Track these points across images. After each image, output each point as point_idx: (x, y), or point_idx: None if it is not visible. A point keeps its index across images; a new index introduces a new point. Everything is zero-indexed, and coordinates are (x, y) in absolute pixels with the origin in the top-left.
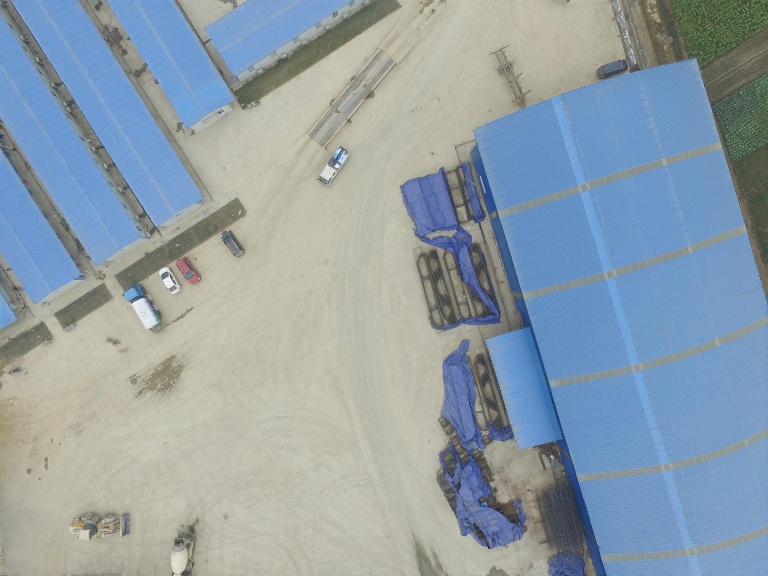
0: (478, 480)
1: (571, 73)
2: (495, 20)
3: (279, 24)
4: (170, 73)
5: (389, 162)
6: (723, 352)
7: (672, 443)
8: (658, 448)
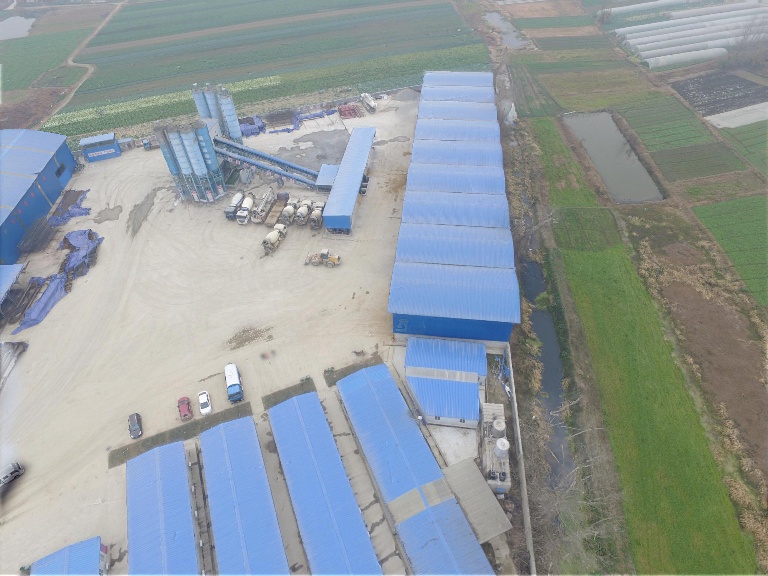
0: None
1: None
2: None
3: None
4: None
5: None
6: None
7: None
8: None
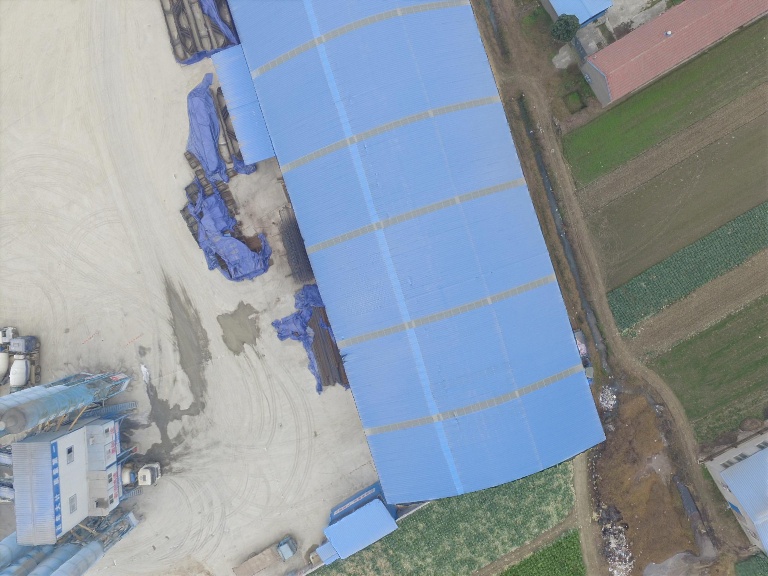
0: (222, 212)
1: None
2: None
3: None
4: None
5: None
6: (406, 23)
7: (355, 114)
8: (342, 121)
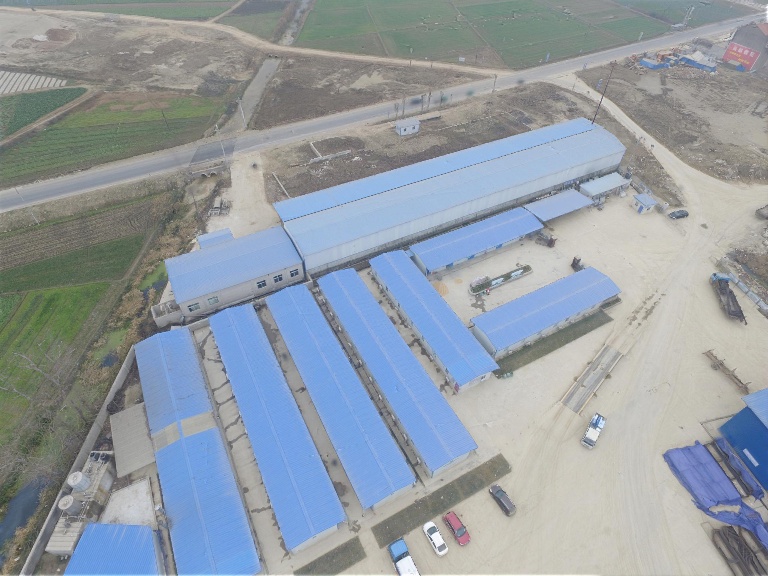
0: None
1: None
2: (691, 333)
3: (530, 320)
4: (445, 345)
5: (643, 432)
6: None
7: None
8: None
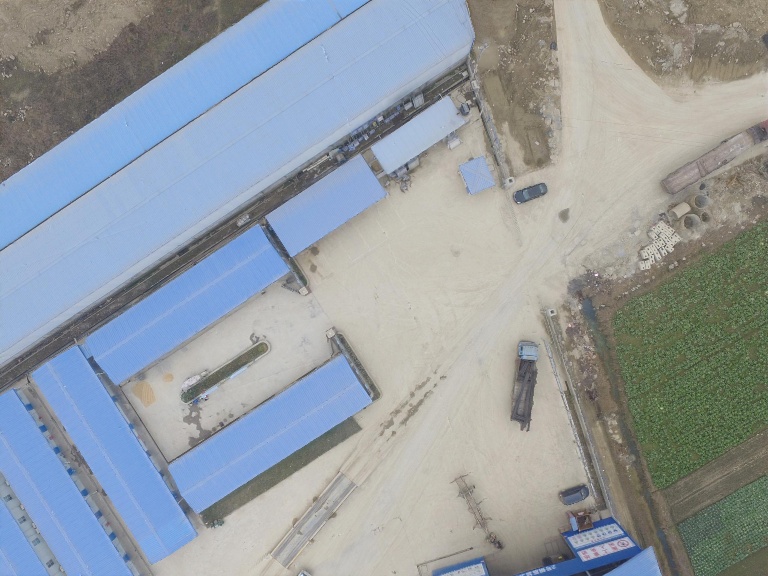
0: None
1: (532, 494)
2: (455, 442)
3: (239, 467)
4: (134, 514)
5: None
6: None
7: None
8: None
